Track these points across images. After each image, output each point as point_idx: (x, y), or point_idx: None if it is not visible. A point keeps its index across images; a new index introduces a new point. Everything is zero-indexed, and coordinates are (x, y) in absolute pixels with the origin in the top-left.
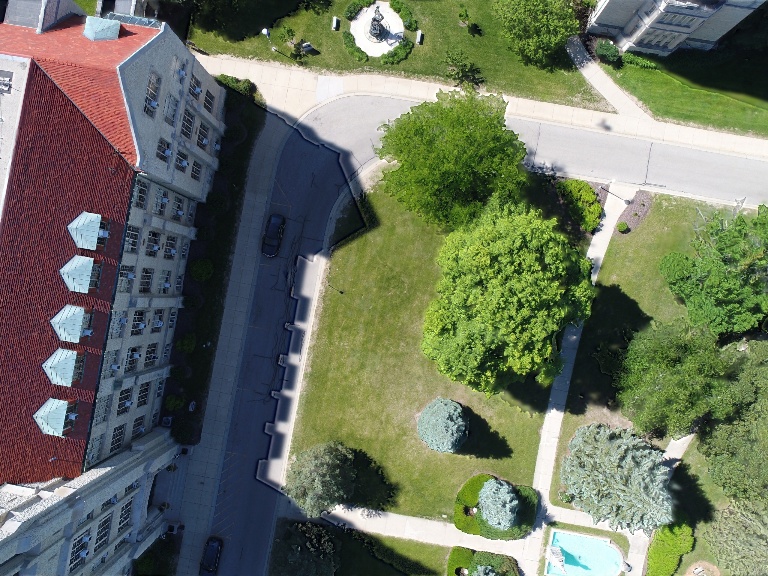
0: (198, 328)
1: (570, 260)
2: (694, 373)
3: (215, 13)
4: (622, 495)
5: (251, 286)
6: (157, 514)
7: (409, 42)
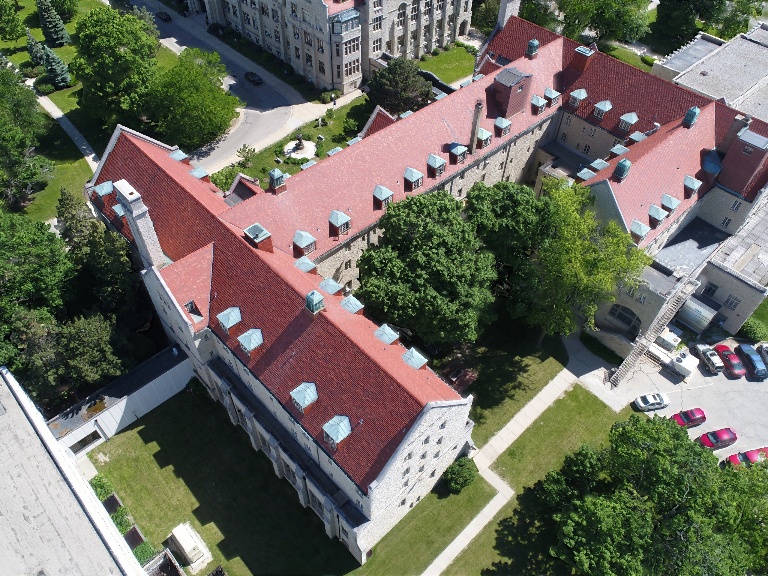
0: (247, 48)
1: (96, 61)
2: (0, 87)
3: (372, 108)
4: (0, 58)
5: (243, 66)
6: (196, 7)
7: (280, 154)
